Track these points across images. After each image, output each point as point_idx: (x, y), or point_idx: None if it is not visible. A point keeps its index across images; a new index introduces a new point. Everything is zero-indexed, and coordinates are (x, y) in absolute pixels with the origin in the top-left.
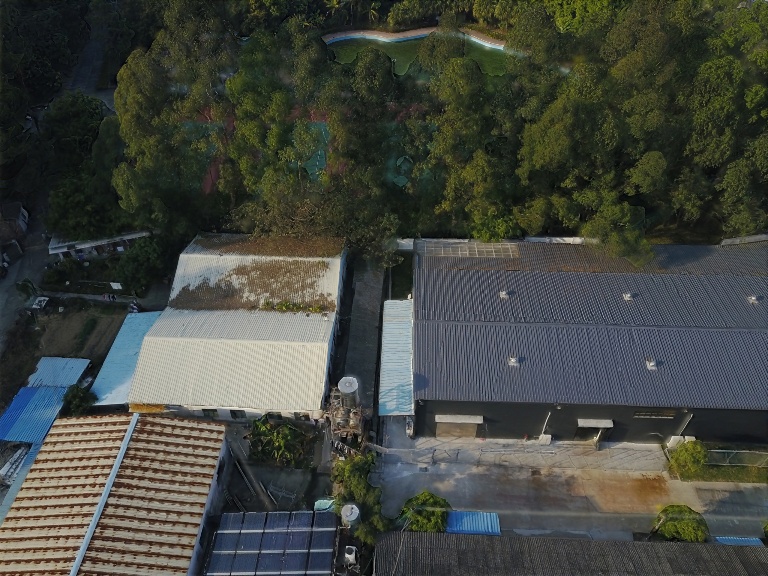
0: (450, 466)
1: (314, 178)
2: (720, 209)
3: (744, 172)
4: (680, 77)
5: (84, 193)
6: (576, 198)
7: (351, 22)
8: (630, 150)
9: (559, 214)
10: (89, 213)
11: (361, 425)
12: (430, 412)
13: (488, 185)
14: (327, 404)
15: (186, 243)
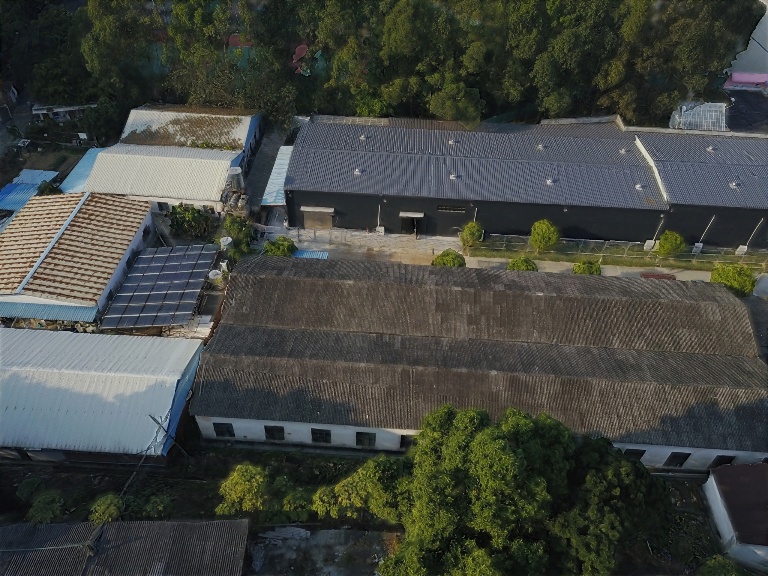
0: (311, 244)
1: None
2: (537, 95)
3: (546, 61)
4: None
5: (61, 68)
6: (427, 79)
7: None
8: (461, 40)
9: (414, 90)
10: (64, 84)
11: (250, 214)
12: (297, 204)
13: (358, 62)
14: None
15: None
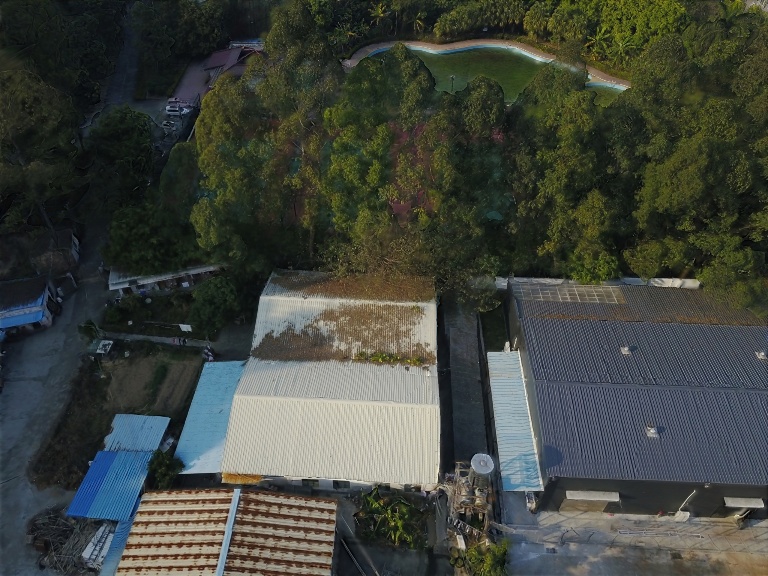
0: (580, 547)
1: (412, 217)
2: None
3: None
4: None
5: (149, 224)
6: (693, 242)
7: (395, 32)
8: (761, 193)
9: (675, 259)
10: (153, 246)
11: None
12: (560, 487)
13: (604, 228)
14: (445, 477)
15: (260, 281)
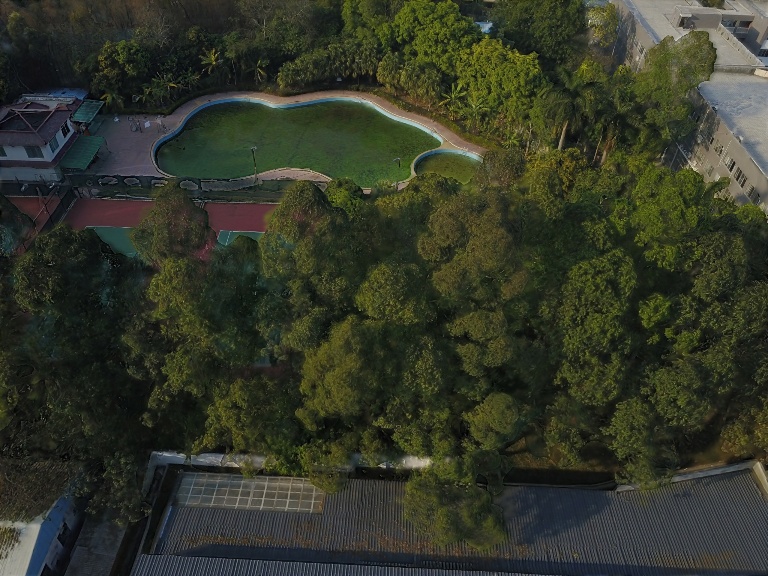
0: None
1: None
2: None
3: (638, 420)
4: (544, 279)
5: None
6: (397, 440)
7: (235, 81)
8: (465, 391)
9: (370, 464)
10: None
11: None
12: None
13: (251, 435)
14: None
15: None
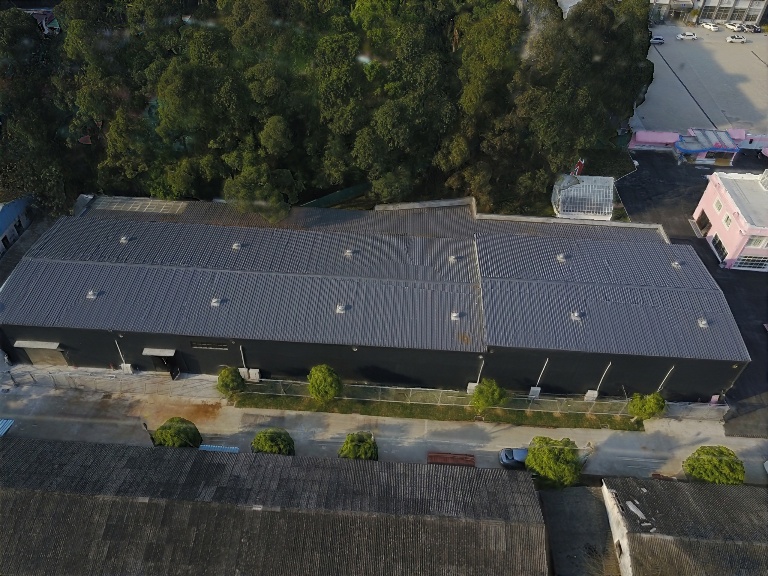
0: (31, 388)
1: None
2: None
3: (366, 139)
4: (307, 50)
5: None
6: (224, 159)
7: None
8: (255, 114)
9: (207, 173)
10: None
11: None
12: (11, 338)
13: (128, 141)
14: None
15: None
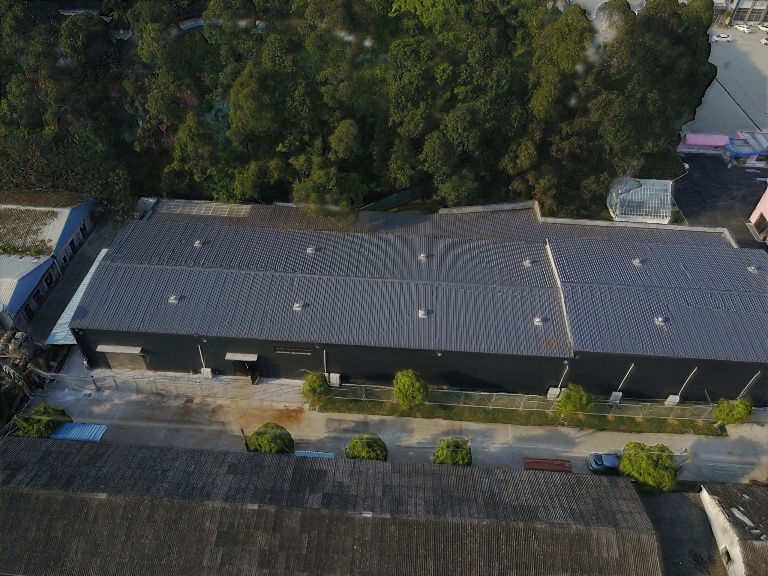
0: (112, 393)
1: None
2: (432, 179)
3: (436, 143)
4: (378, 53)
5: None
6: (292, 162)
7: None
8: (327, 117)
9: (275, 176)
10: None
11: (34, 353)
12: (93, 342)
13: (199, 145)
14: None
15: None
